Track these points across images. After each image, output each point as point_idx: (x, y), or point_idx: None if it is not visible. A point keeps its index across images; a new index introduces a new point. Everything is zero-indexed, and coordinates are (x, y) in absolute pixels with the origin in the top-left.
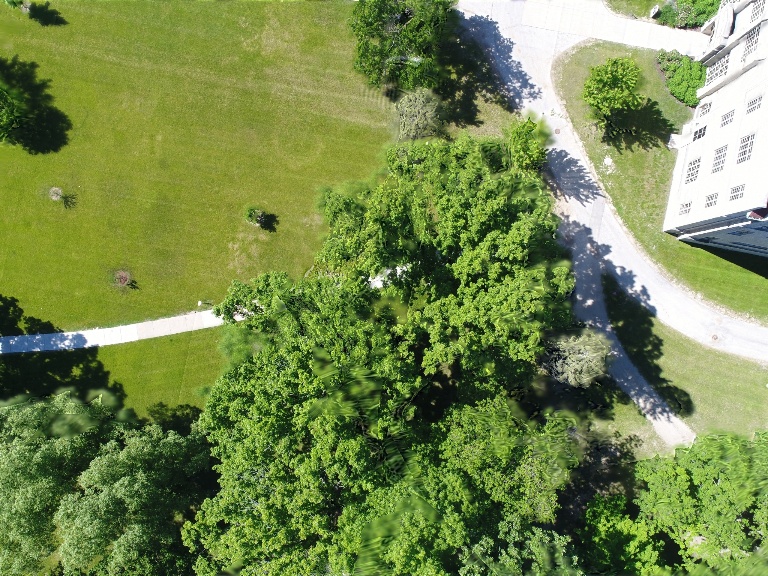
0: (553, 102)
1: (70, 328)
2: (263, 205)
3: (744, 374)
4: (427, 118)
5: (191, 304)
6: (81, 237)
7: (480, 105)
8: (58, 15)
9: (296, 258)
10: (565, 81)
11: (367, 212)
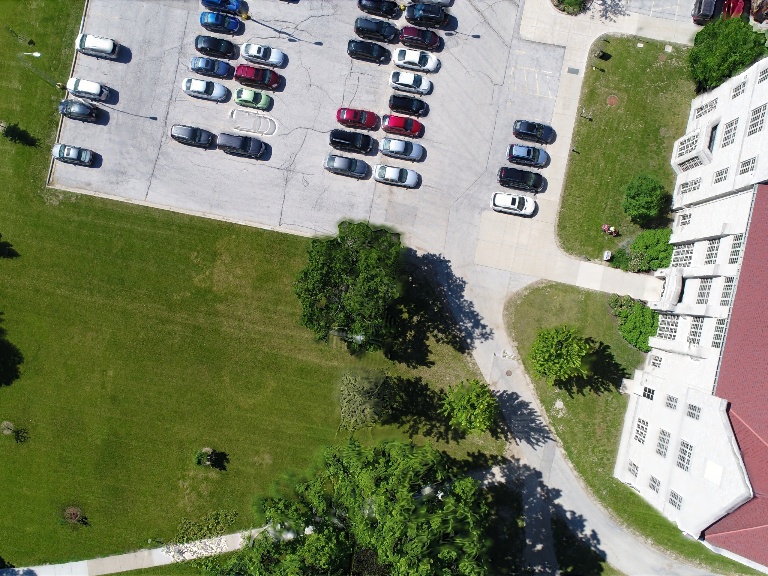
0: (505, 343)
1: (21, 563)
2: (214, 443)
3: None
4: (366, 414)
5: (141, 541)
6: (32, 472)
7: (431, 345)
8: (10, 247)
9: (246, 497)
10: (517, 322)
11: (291, 572)
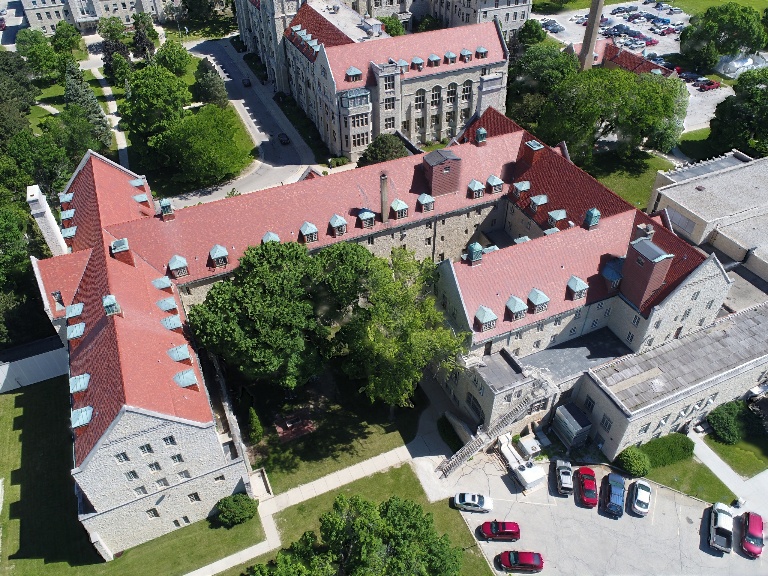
0: None
1: None
2: None
3: None
4: None
5: None
6: None
7: None
8: None
9: None
10: None
11: None
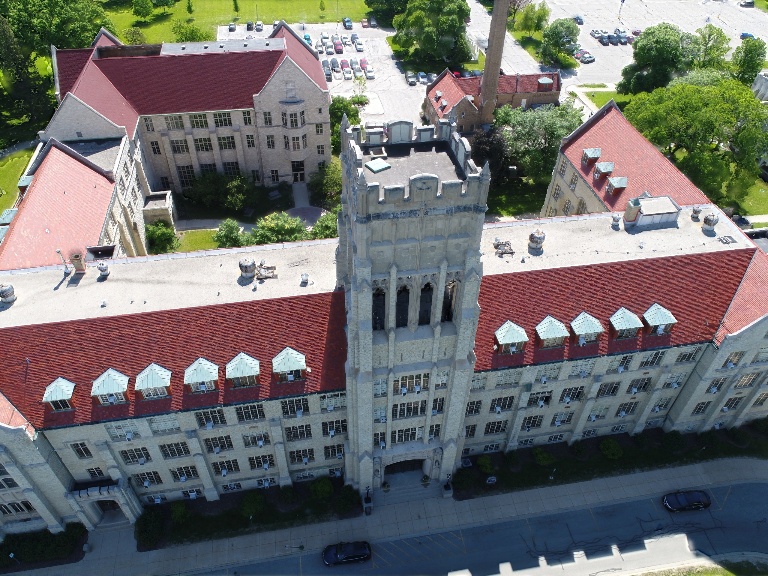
0: None
1: None
2: None
3: (14, 185)
4: (130, 31)
5: None
6: None
7: None
8: None
9: None
10: None
11: None
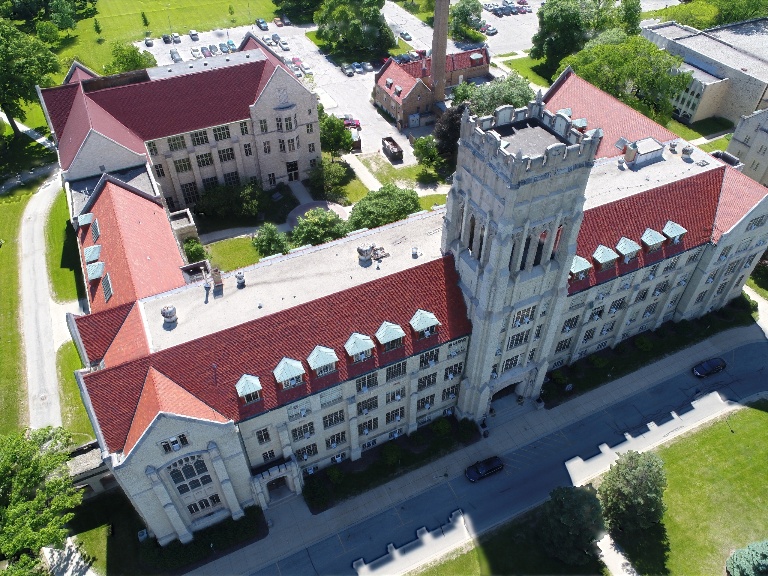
0: None
1: None
2: None
3: (8, 232)
4: (70, 60)
5: None
6: None
7: None
8: None
9: None
10: None
11: None
